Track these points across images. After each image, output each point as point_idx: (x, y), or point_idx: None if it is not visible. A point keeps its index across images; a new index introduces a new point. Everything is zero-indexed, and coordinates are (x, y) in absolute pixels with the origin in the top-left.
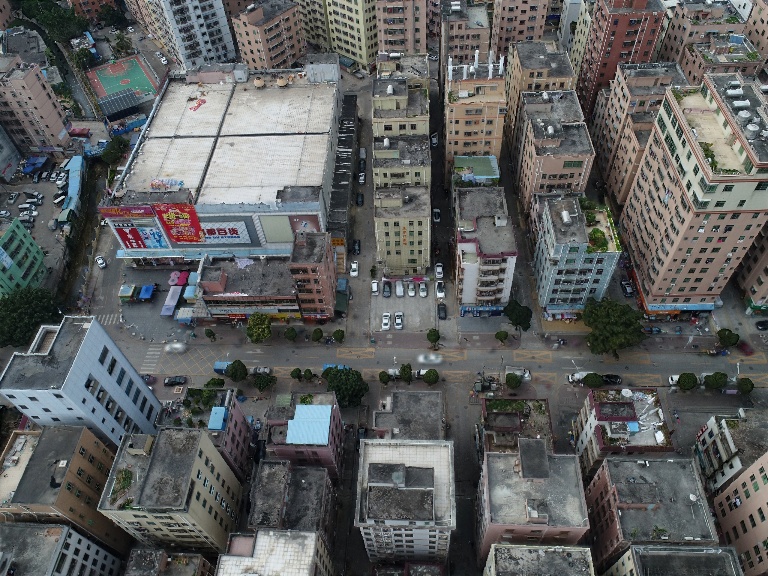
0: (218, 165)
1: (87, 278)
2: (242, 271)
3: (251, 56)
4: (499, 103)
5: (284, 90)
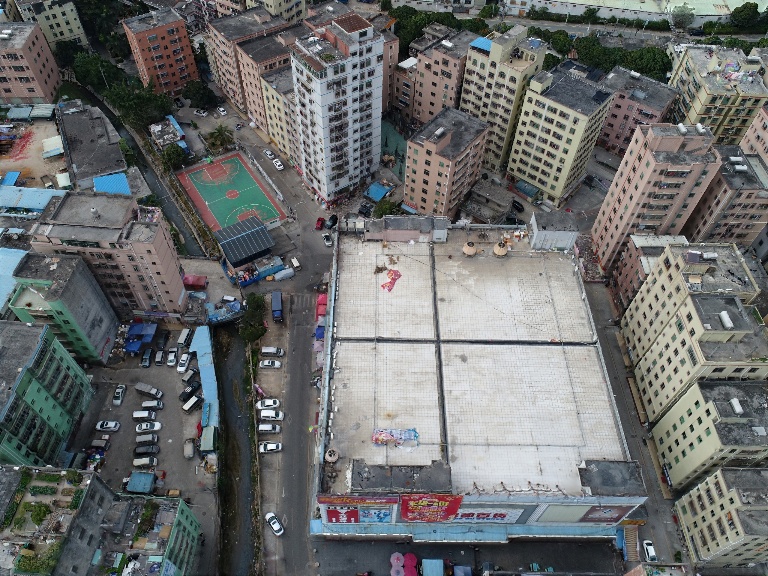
0: (457, 399)
1: (262, 558)
2: None
3: (422, 186)
4: None
5: (503, 260)
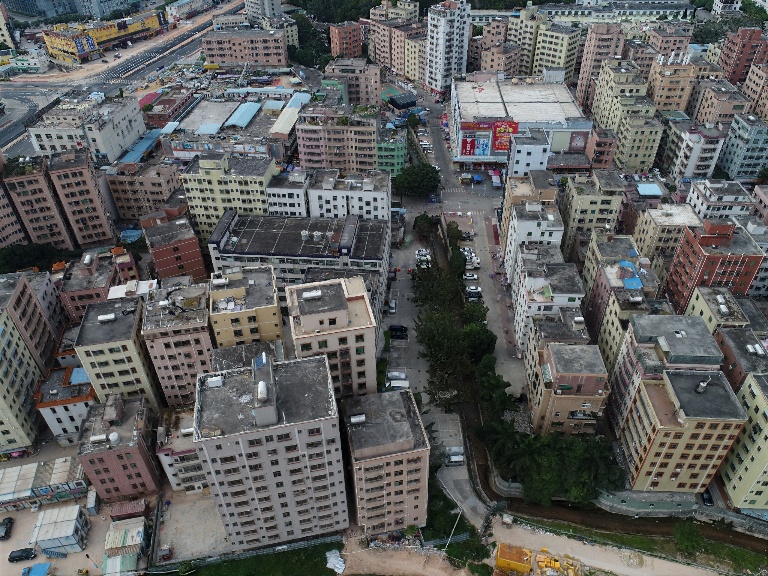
0: (513, 113)
1: None
2: (550, 157)
3: None
4: (690, 77)
5: (531, 85)
